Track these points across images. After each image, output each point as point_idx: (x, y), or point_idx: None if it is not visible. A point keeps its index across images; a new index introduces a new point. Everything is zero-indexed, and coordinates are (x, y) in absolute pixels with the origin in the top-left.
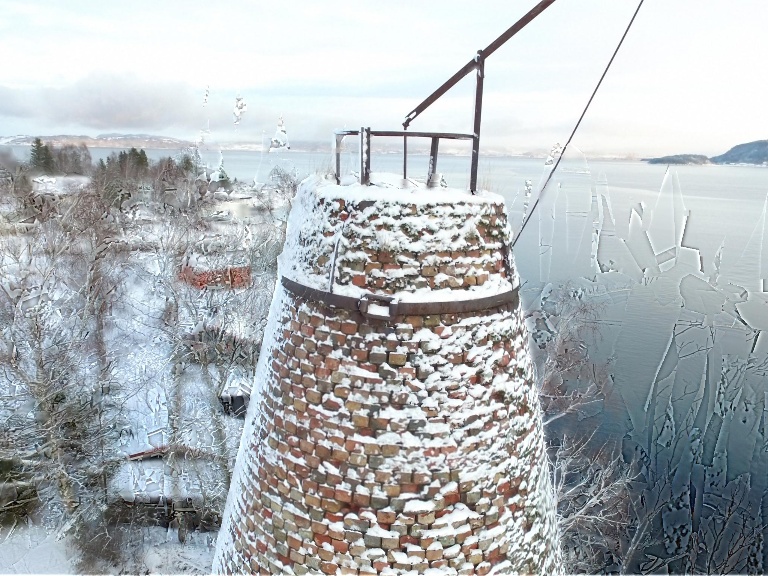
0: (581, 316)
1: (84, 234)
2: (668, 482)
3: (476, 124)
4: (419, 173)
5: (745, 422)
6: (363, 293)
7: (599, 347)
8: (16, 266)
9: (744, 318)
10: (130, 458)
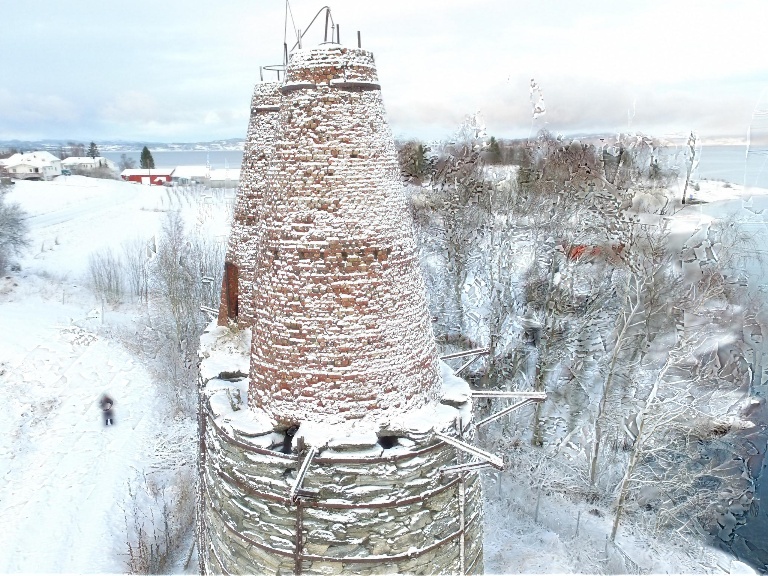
0: (744, 246)
1: None
2: None
3: None
4: (673, 130)
5: None
6: None
7: (764, 278)
8: None
9: None
10: None
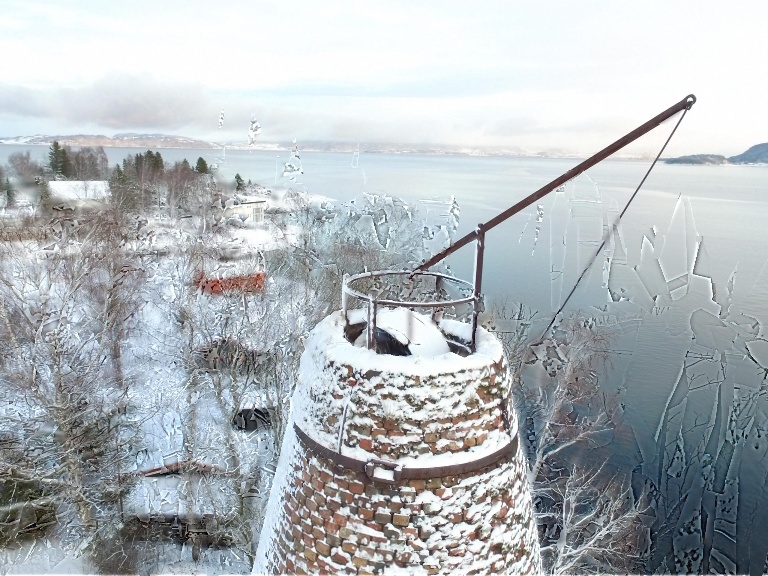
0: (592, 345)
1: (102, 263)
2: (668, 570)
3: (477, 288)
4: (431, 195)
5: (757, 448)
6: (369, 458)
7: (610, 375)
8: (36, 291)
9: (754, 357)
10: (146, 478)
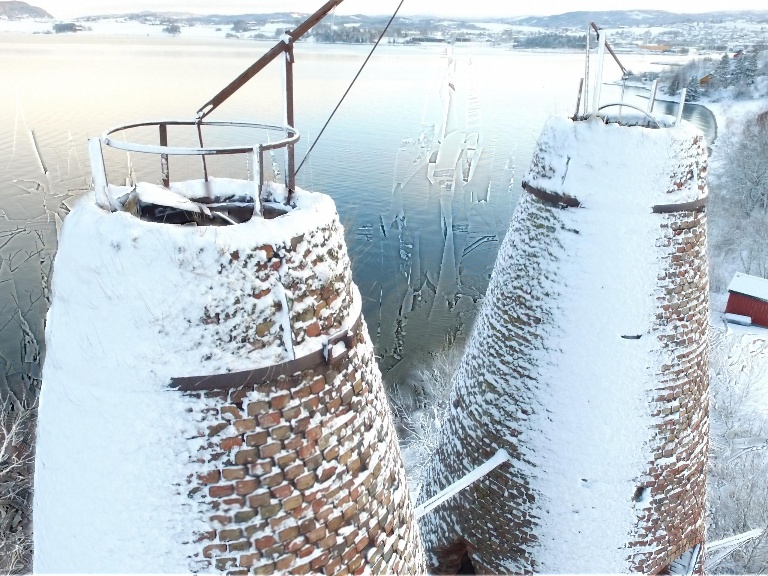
0: None
1: None
2: None
3: None
4: None
5: None
6: (325, 341)
7: None
8: None
9: None
10: None
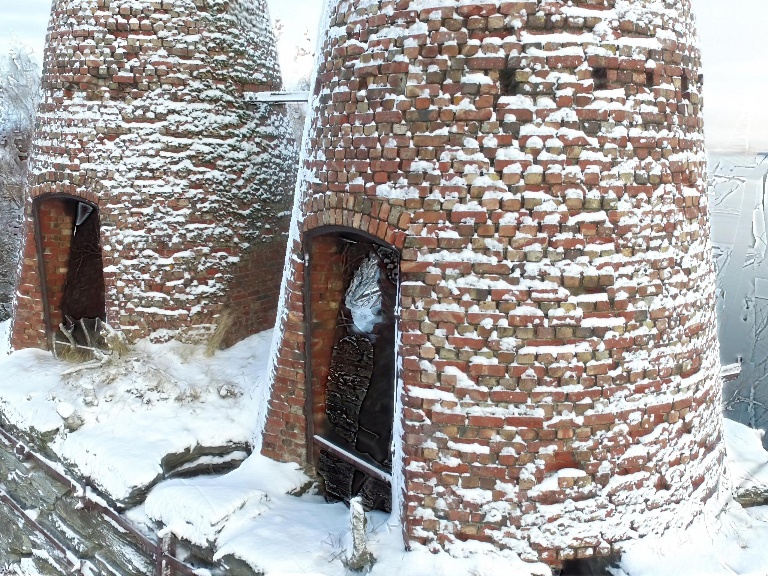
0: None
1: None
2: None
3: None
4: None
5: (746, 320)
6: None
7: None
8: None
9: None
10: None
